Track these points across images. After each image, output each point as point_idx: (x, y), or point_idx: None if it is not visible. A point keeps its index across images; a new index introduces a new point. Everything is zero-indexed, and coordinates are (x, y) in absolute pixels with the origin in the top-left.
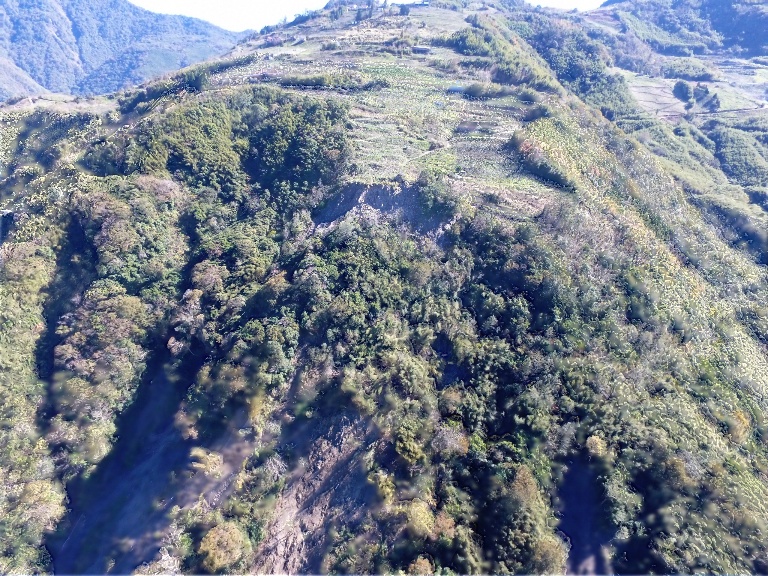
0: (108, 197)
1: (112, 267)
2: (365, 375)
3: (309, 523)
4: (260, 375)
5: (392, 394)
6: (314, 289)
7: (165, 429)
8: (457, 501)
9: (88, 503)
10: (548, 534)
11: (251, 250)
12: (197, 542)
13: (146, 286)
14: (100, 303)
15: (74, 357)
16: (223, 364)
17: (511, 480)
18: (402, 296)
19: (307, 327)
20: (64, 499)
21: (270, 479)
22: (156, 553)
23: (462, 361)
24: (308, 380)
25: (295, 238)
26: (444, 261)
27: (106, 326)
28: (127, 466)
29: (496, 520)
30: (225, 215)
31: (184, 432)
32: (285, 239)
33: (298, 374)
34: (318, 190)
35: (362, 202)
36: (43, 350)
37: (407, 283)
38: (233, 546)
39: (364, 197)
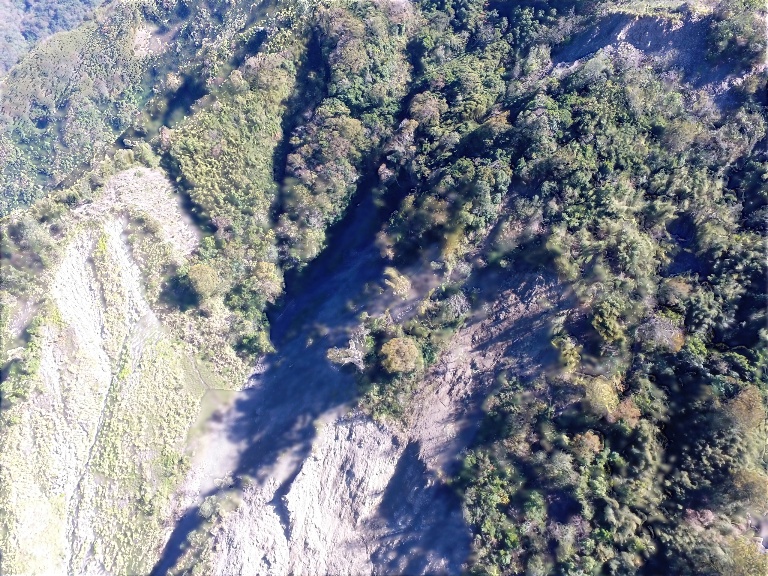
0: (346, 14)
1: (341, 87)
2: (575, 239)
3: (480, 364)
4: (462, 213)
5: (603, 265)
6: (539, 134)
7: (364, 249)
8: (649, 395)
9: (298, 292)
10: (760, 467)
11: (475, 85)
12: (378, 347)
13: (367, 111)
14: (327, 120)
15: (301, 167)
16: (428, 196)
17: (729, 396)
18: (645, 160)
19: (522, 174)
20: (282, 283)
21: (451, 314)
22: (344, 345)
23: (704, 252)
24: (509, 231)
25: (526, 78)
26: (717, 126)
27: (329, 143)
28: (330, 272)
29: (692, 430)
30: (454, 45)
31: (382, 251)
32: (514, 78)
33: (500, 223)
34: (567, 21)
35: (622, 39)
36: (278, 157)
37: (657, 145)
38: (409, 358)
39: (626, 32)
